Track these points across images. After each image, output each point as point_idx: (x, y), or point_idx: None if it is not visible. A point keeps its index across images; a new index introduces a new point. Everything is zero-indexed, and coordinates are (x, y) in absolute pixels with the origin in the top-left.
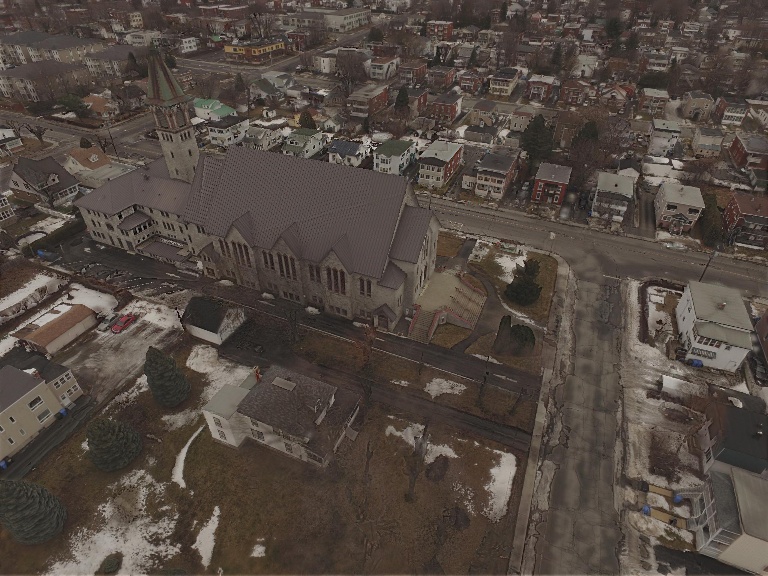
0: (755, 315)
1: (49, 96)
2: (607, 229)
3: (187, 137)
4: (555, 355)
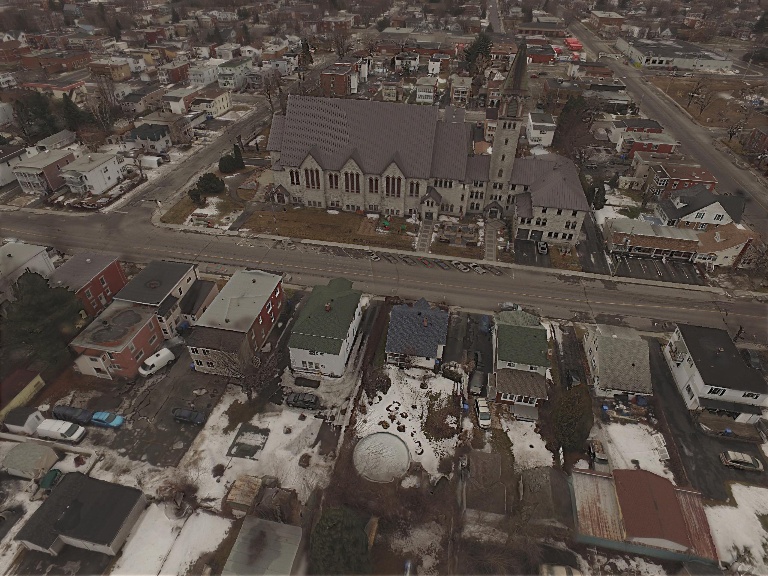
0: (38, 198)
1: None
2: (65, 259)
3: None
4: (208, 171)
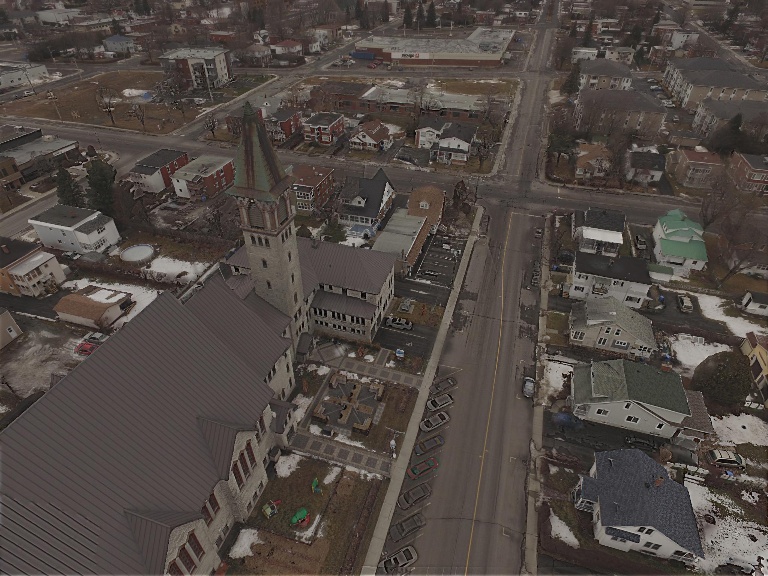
0: None
1: (586, 128)
2: None
3: (264, 244)
4: None
